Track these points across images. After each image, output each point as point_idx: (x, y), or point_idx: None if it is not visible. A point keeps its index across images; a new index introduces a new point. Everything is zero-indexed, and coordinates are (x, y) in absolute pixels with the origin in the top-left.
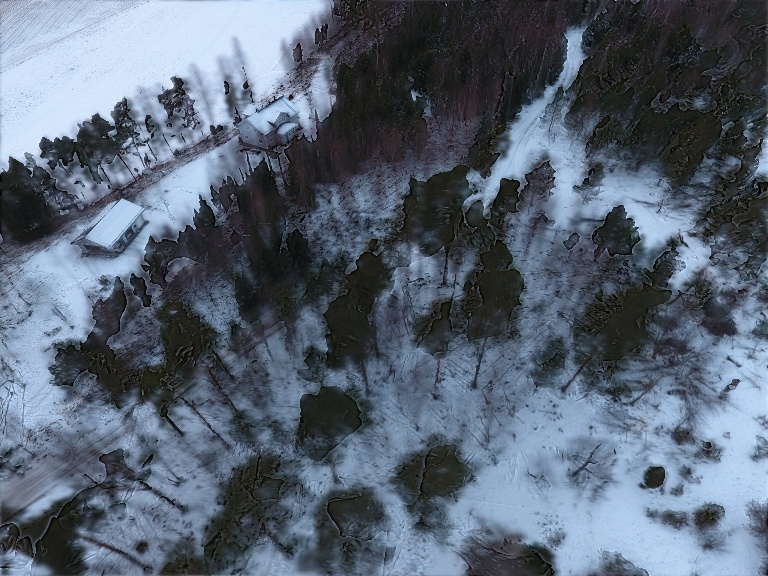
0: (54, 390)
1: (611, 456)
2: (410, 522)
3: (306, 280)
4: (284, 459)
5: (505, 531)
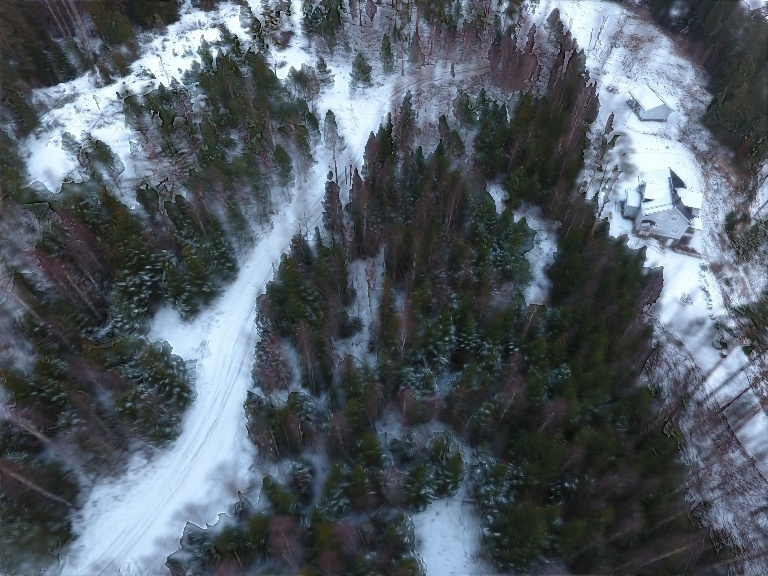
0: None
1: (349, 14)
2: None
3: (493, 75)
4: (458, 30)
5: (384, 8)
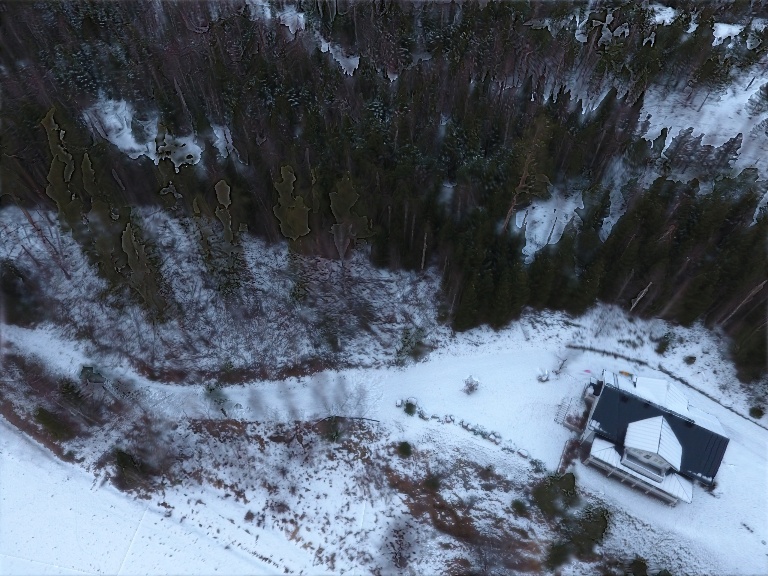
0: None
1: None
2: None
3: None
4: None
5: None
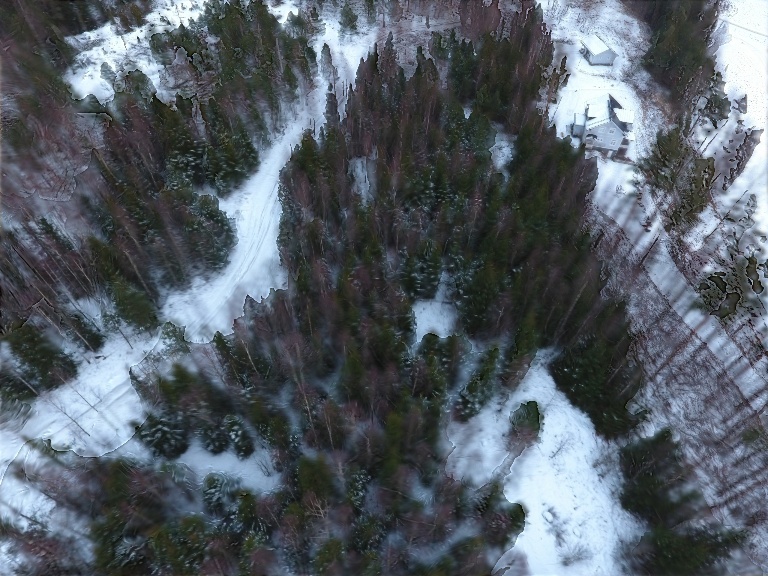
0: None
1: None
2: None
3: (463, 29)
4: None
5: None
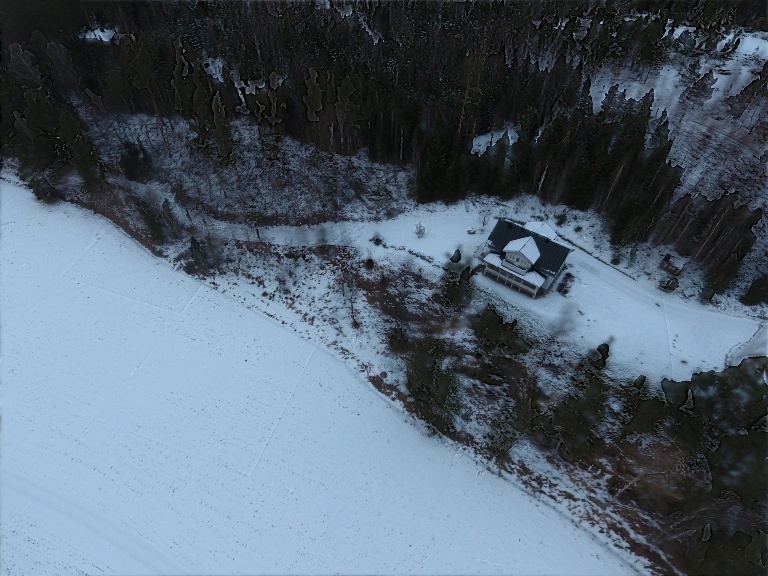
0: None
1: None
2: None
3: None
4: None
5: None
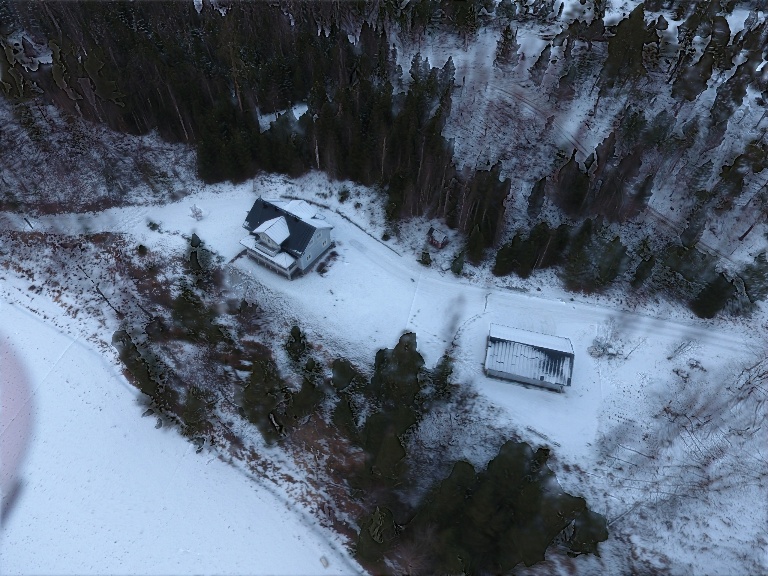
0: (741, 341)
1: None
2: (756, 132)
3: None
4: None
5: None
